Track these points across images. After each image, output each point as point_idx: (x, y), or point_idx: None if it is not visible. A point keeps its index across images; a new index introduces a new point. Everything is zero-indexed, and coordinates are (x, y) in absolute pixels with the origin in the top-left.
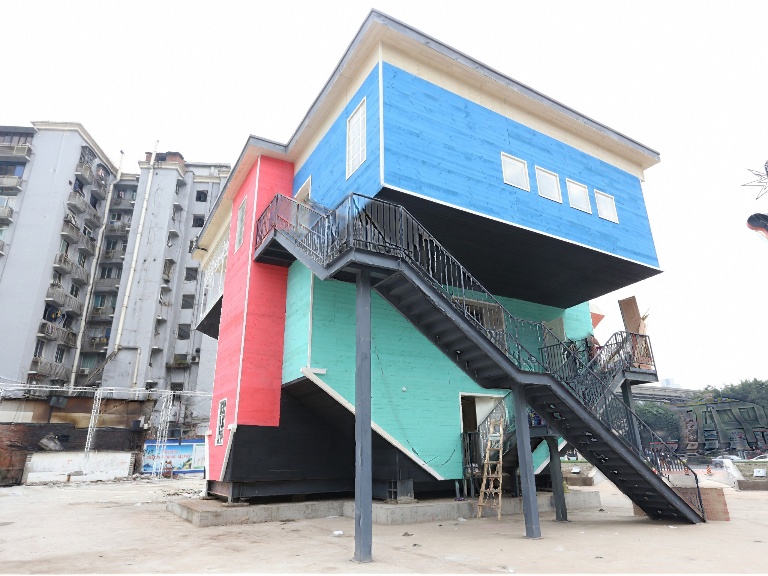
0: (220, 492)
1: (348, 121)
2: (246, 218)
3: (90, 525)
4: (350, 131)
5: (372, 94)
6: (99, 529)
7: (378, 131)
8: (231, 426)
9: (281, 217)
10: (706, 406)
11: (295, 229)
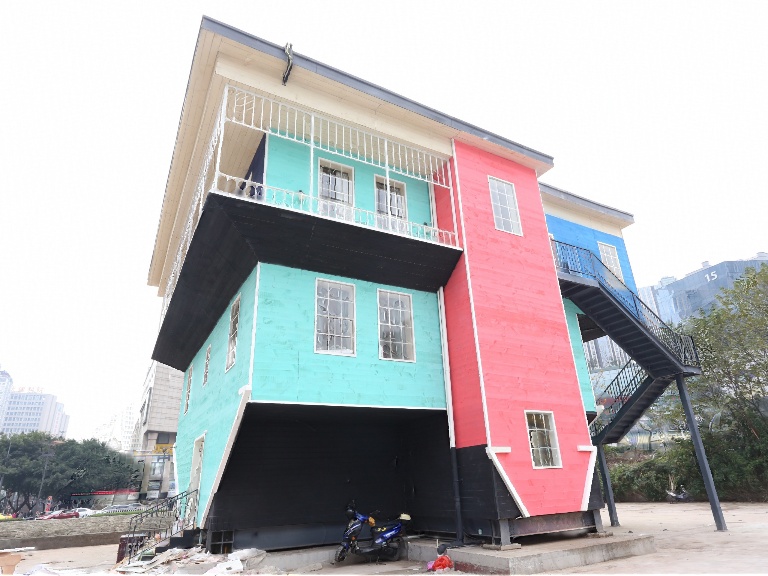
0: (549, 529)
1: (598, 243)
2: (524, 214)
3: (706, 574)
4: (602, 252)
5: (622, 253)
6: (727, 566)
7: (634, 283)
8: (594, 448)
9: (607, 281)
10: (158, 457)
11: (637, 311)
